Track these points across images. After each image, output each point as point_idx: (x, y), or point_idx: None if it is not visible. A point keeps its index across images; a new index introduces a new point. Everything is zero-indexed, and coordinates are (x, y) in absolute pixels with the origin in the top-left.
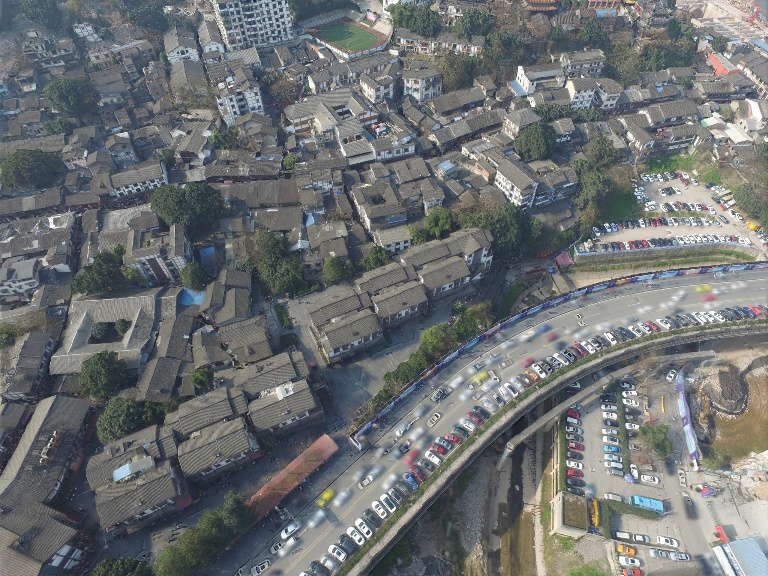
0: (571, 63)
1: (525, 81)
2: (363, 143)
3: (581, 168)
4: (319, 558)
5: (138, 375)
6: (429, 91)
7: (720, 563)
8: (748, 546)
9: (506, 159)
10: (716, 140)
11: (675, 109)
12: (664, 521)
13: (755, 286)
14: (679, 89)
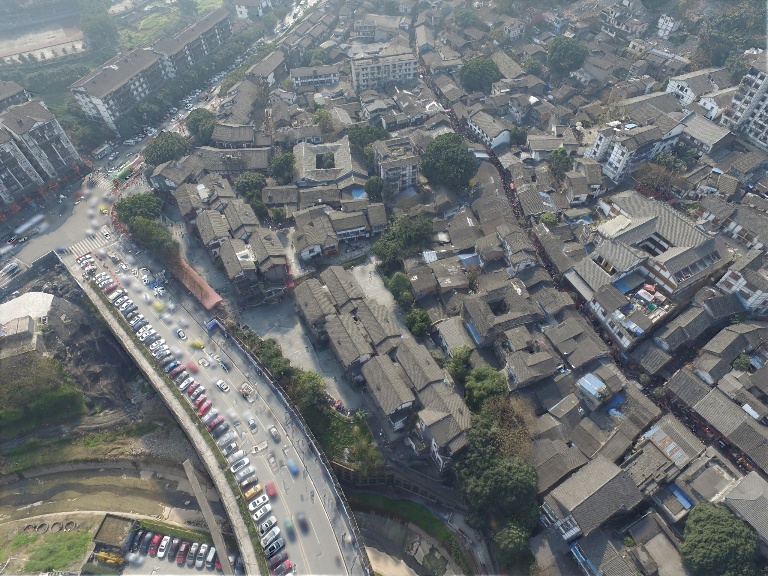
0: None
1: None
2: (604, 278)
3: None
4: (138, 310)
5: None
6: None
7: None
8: None
9: None
10: None
11: None
12: None
13: None
14: None
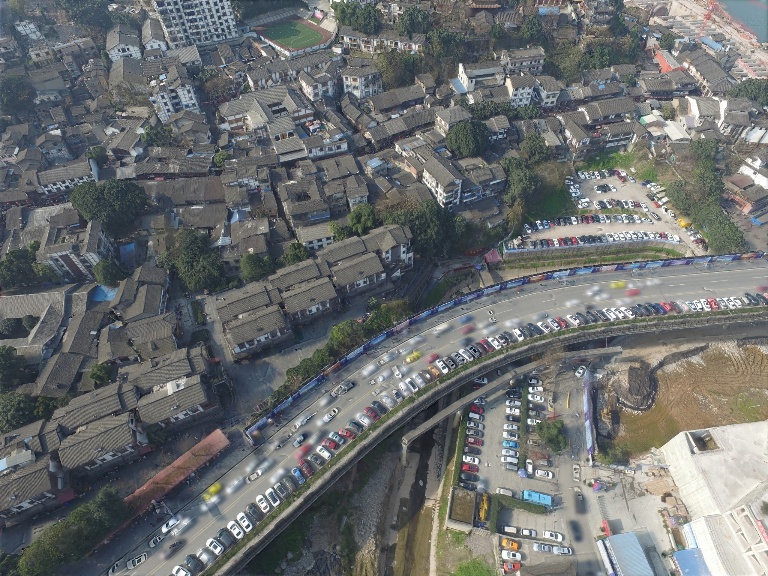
0: (510, 61)
1: (465, 79)
2: (295, 140)
3: (509, 165)
4: (196, 551)
5: (39, 370)
6: (369, 89)
7: (602, 557)
8: (627, 540)
9: (432, 156)
10: (654, 137)
11: (613, 106)
12: (553, 515)
13: (670, 282)
14: (622, 87)
